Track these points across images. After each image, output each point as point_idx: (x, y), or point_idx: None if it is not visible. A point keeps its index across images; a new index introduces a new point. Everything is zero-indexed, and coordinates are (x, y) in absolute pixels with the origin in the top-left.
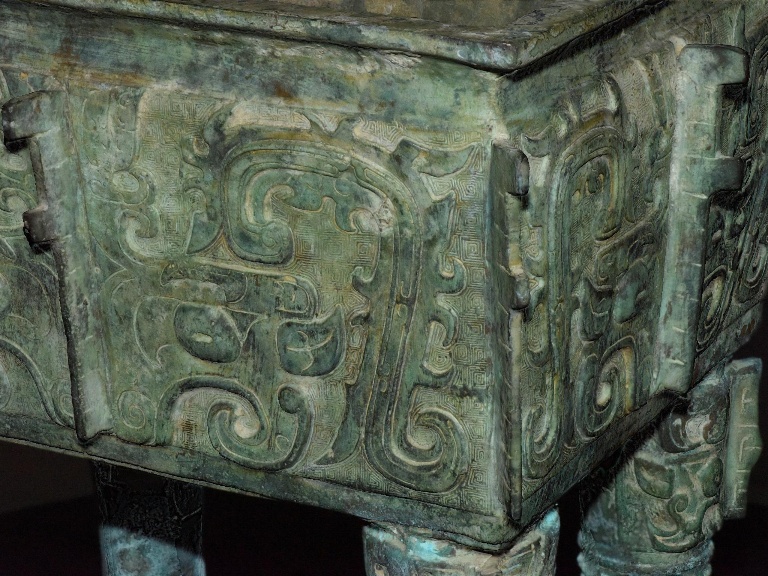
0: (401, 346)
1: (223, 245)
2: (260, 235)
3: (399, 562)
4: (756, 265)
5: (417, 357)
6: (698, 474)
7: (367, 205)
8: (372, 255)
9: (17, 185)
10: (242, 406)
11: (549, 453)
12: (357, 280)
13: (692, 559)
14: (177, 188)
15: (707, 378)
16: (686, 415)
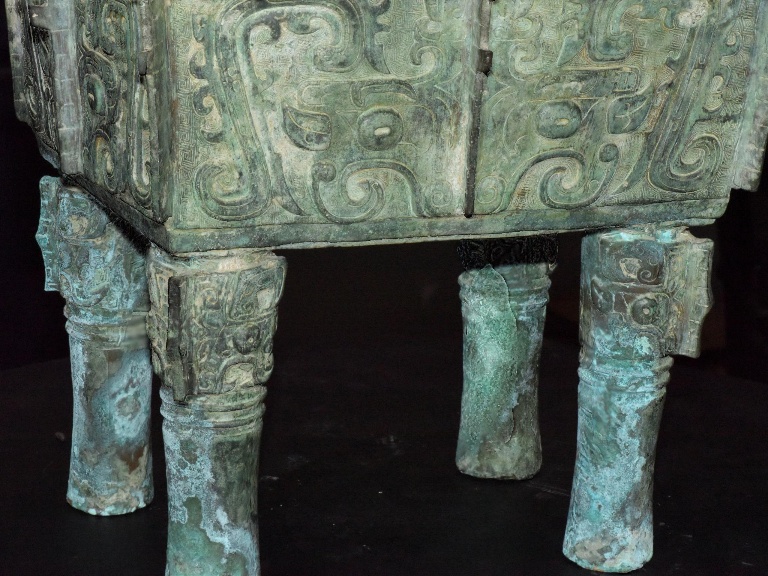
0: (693, 97)
1: (583, 55)
2: (617, 41)
3: (657, 248)
4: None
5: (701, 102)
6: None
7: (688, 8)
8: (681, 41)
9: (433, 43)
10: (568, 167)
11: None
12: (671, 60)
13: None
14: (558, 22)
15: None
16: None
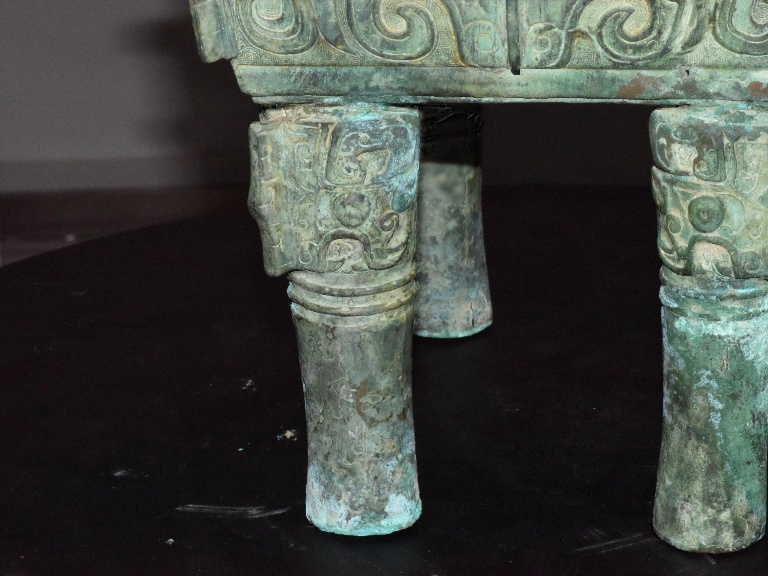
0: None
1: None
2: None
3: None
4: (765, 23)
5: None
6: (688, 203)
7: None
8: None
9: None
10: None
11: (289, 37)
12: None
13: (697, 289)
14: None
15: (701, 113)
16: (671, 137)
